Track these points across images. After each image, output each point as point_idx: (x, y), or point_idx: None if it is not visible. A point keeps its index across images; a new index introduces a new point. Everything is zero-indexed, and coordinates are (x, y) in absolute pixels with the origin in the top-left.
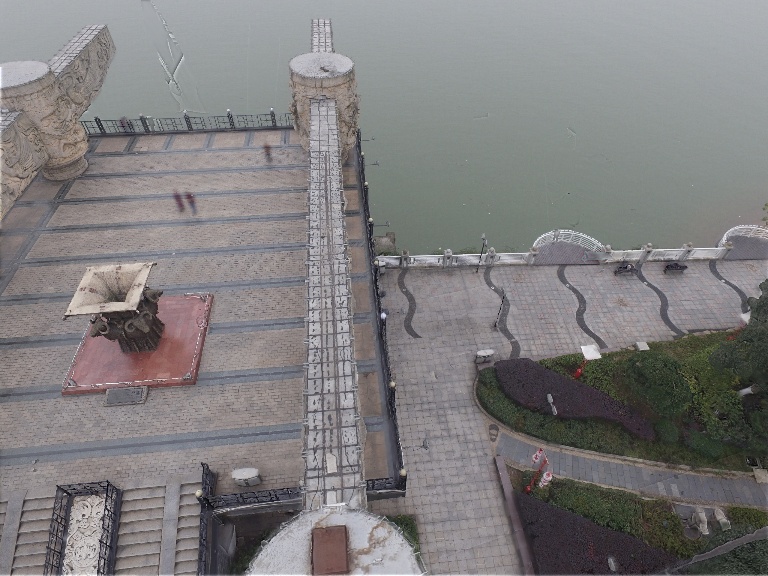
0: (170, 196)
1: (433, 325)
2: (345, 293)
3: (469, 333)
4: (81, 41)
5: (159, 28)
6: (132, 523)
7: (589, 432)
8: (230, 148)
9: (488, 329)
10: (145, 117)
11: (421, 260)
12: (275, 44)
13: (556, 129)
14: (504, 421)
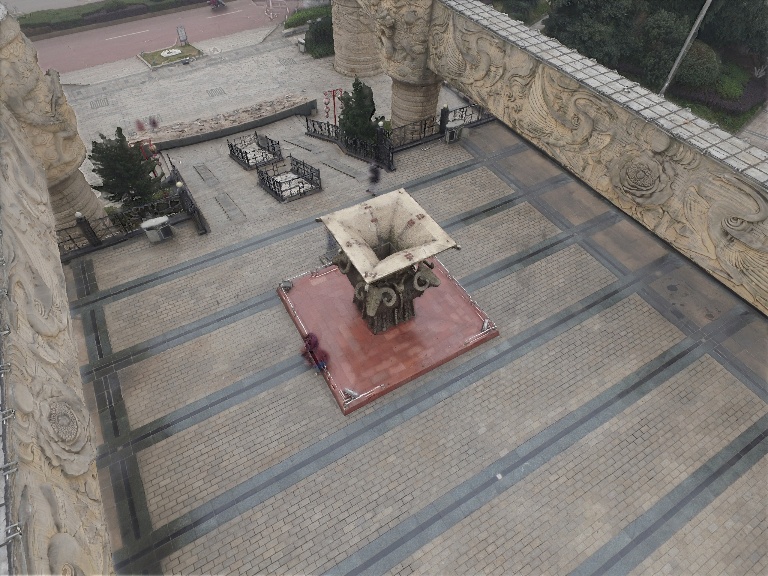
0: None
1: None
2: None
3: None
4: None
5: None
6: None
7: None
8: None
9: None
10: None
11: None
12: None
13: None
14: None
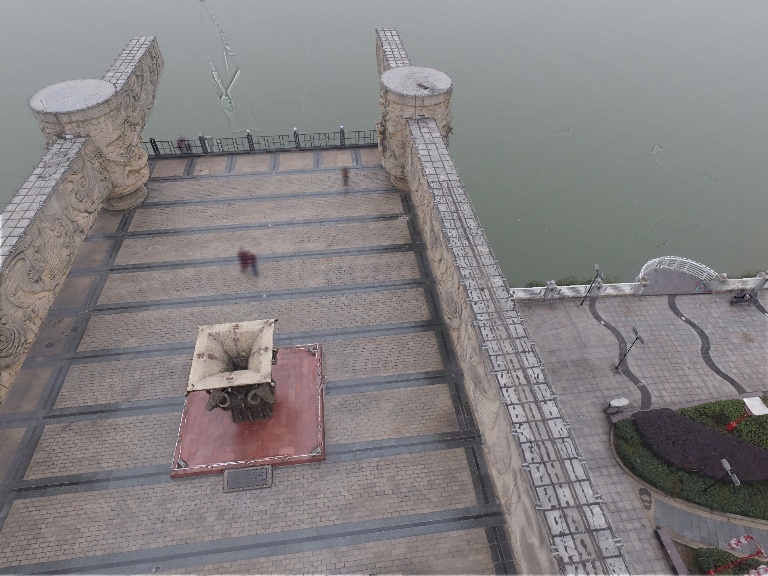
0: (245, 227)
1: (548, 368)
2: (536, 363)
3: (589, 377)
4: (133, 55)
5: (217, 40)
6: None
7: (759, 498)
8: (299, 170)
9: (609, 372)
10: (204, 137)
11: (521, 293)
12: (338, 56)
13: (644, 144)
14: (658, 485)
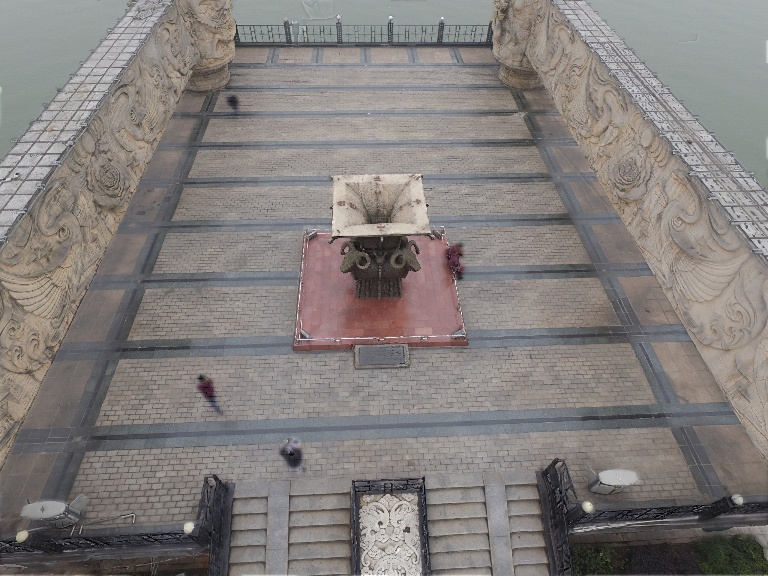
0: (342, 114)
1: None
2: None
3: None
4: None
5: None
6: (444, 537)
7: None
8: (394, 64)
9: None
10: (290, 23)
11: None
12: None
13: None
14: None
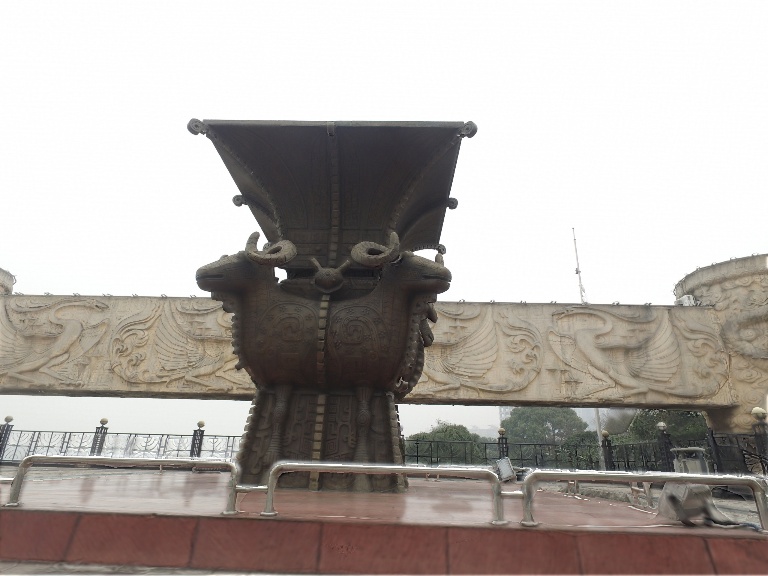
0: None
1: None
2: None
3: None
4: None
5: None
6: None
7: None
8: None
9: None
10: None
11: None
12: None
13: None
14: None
